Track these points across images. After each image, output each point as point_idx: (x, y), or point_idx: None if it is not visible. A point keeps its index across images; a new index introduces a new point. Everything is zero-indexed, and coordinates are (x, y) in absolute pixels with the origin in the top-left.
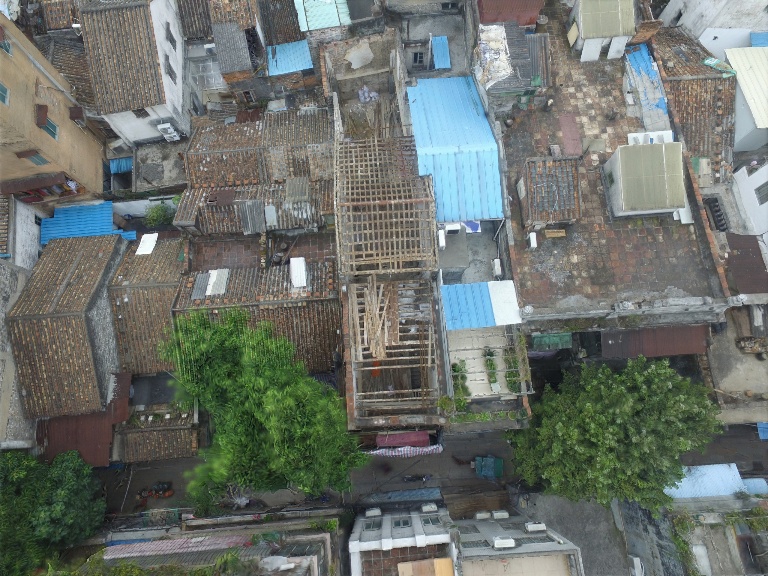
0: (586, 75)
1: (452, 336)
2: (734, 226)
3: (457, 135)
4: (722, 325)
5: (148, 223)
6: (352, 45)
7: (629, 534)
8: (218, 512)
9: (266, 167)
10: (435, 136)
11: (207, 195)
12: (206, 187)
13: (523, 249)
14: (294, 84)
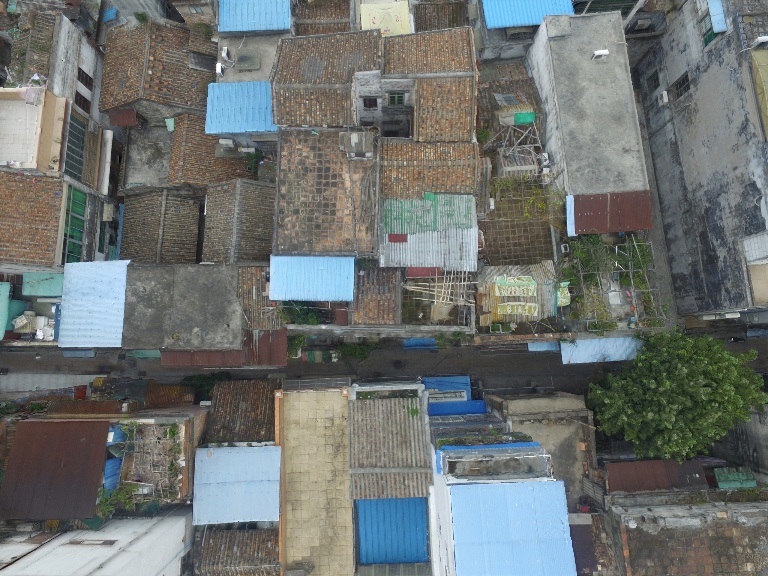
0: None
1: None
2: None
3: None
4: None
5: None
6: None
7: None
8: None
9: None
10: None
11: None
12: None
13: None
14: None
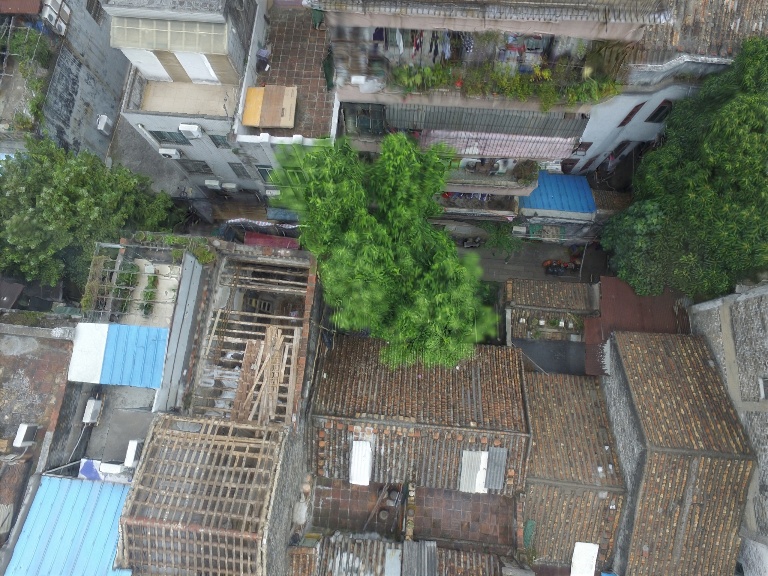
0: None
1: None
2: None
3: None
4: None
5: None
6: None
7: (102, 151)
8: (487, 226)
9: None
10: None
11: None
12: None
13: (45, 429)
14: None
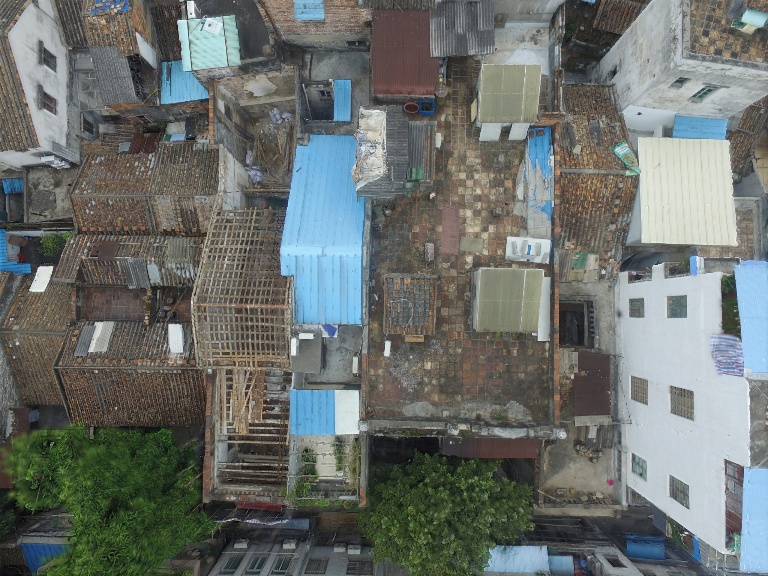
0: (482, 158)
1: (295, 438)
2: (606, 327)
3: (327, 230)
4: (553, 440)
5: (45, 252)
6: (248, 79)
7: None
8: None
9: (154, 215)
10: (305, 229)
11: (90, 246)
12: (93, 231)
13: (381, 351)
14: (193, 108)
